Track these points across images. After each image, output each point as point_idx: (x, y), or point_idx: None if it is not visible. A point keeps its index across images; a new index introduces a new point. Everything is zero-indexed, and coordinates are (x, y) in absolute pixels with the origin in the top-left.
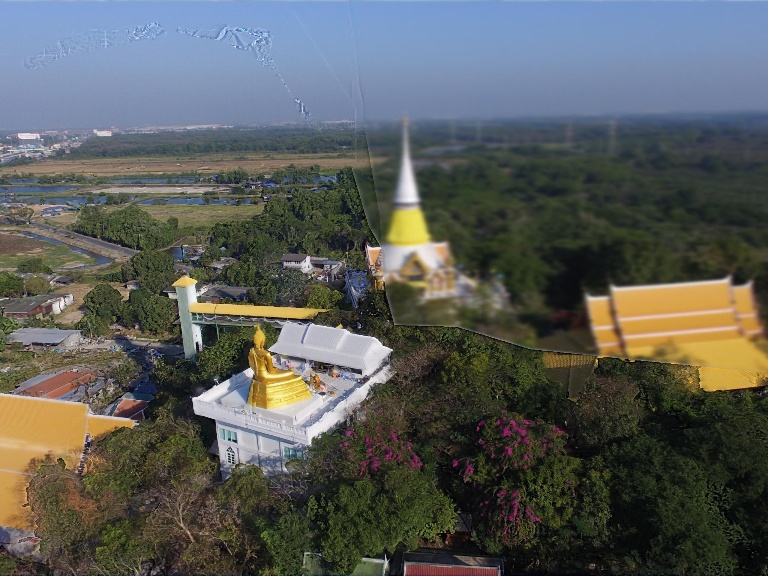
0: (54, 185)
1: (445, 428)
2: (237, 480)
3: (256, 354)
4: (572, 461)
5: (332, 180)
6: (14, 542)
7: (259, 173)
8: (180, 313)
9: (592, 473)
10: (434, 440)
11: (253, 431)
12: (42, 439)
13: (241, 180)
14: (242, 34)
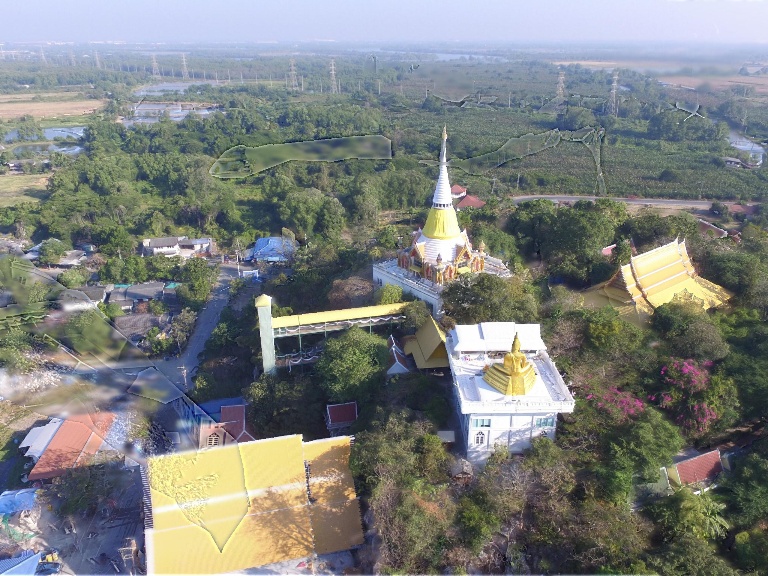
0: None
1: (634, 377)
2: (547, 450)
3: (515, 357)
4: None
5: (71, 136)
6: (286, 573)
7: None
8: (261, 331)
9: (729, 382)
10: (633, 387)
11: (509, 414)
12: (257, 479)
13: None
14: None
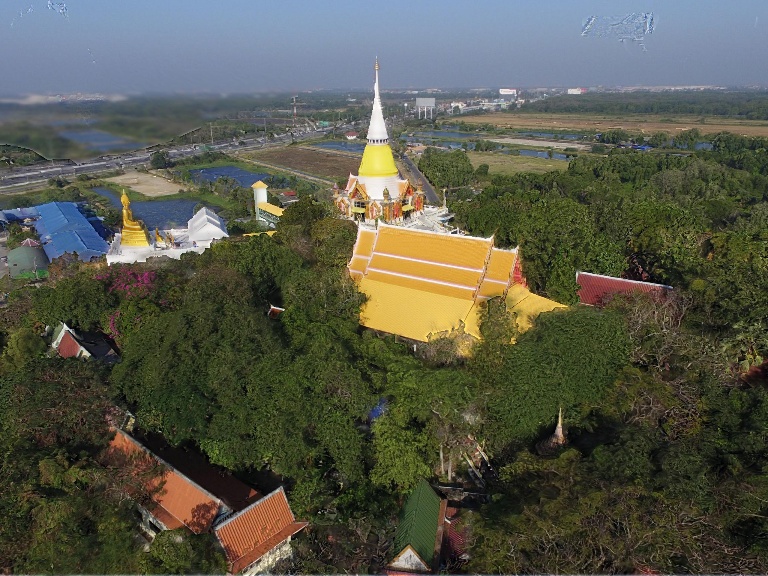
0: (468, 132)
1: None
2: None
3: None
4: (148, 305)
5: None
6: None
7: (639, 134)
8: None
9: None
10: None
11: None
12: None
13: (618, 140)
14: (55, 6)
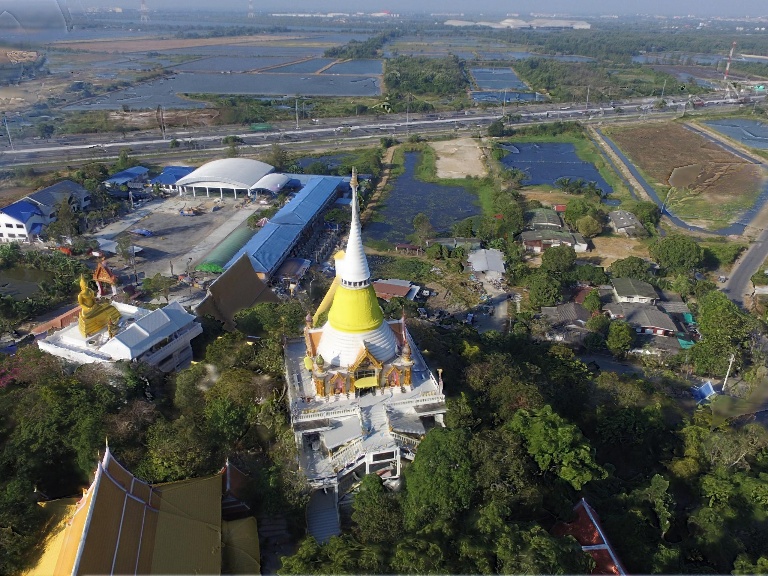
0: None
1: None
2: None
3: None
4: None
5: None
6: None
7: None
8: None
9: None
10: None
11: None
12: None
13: None
14: None
